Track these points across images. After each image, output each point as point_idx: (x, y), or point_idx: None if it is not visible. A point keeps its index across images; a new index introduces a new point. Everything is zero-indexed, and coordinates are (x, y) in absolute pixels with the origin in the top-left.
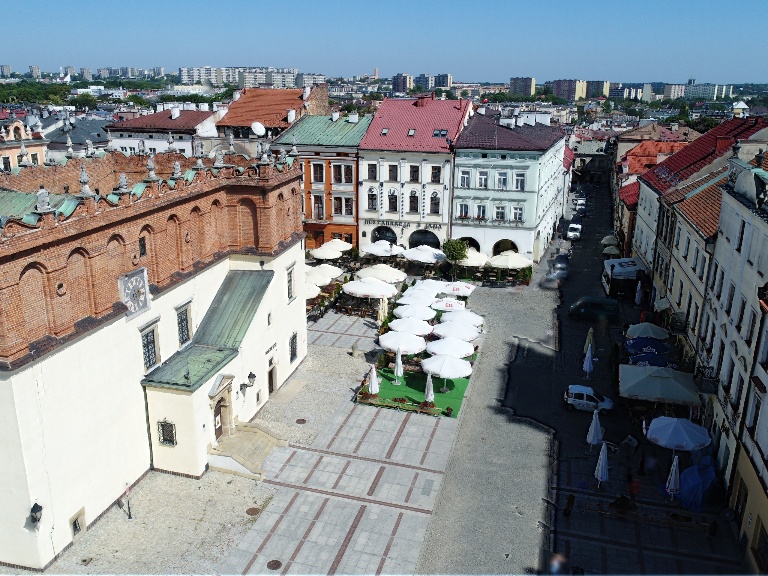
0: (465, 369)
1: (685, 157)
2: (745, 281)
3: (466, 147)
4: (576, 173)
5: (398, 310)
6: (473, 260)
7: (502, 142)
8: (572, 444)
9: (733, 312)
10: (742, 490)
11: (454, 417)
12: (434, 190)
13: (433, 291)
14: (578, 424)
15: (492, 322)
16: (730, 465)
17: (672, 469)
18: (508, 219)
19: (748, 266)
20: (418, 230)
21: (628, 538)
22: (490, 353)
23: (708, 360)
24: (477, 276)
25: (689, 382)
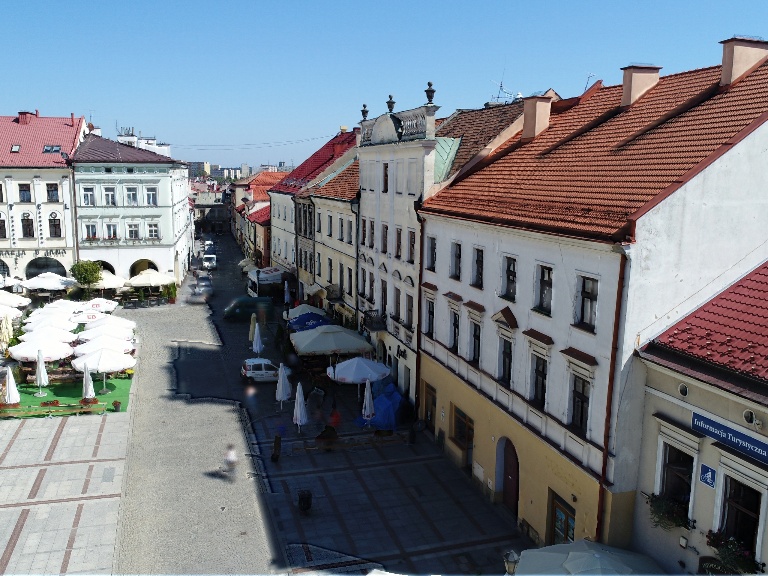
0: (128, 360)
1: (308, 167)
2: (397, 211)
3: (86, 160)
4: (197, 224)
5: (28, 326)
6: (109, 282)
7: (127, 156)
8: (261, 408)
9: (390, 246)
10: (428, 397)
11: (123, 411)
12: (52, 211)
13: (68, 309)
14: (262, 393)
15: (144, 333)
16: (413, 381)
17: (366, 394)
18: (143, 237)
19: (398, 196)
20: (36, 259)
21: (341, 464)
22: (149, 356)
23: (370, 309)
24: (116, 299)
25: (357, 335)
